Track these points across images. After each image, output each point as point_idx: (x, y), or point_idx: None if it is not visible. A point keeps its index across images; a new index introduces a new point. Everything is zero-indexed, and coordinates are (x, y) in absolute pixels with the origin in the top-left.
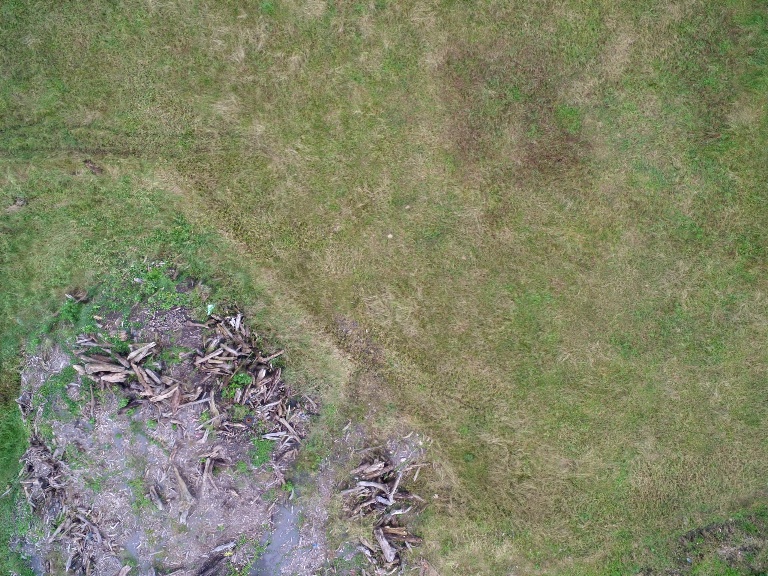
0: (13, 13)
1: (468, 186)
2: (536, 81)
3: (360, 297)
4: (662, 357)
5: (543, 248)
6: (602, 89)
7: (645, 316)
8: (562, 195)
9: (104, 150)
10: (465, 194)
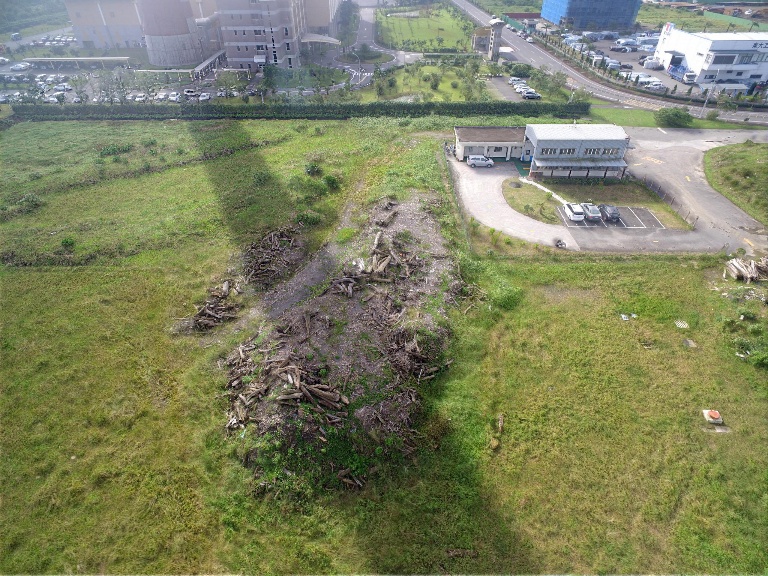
0: None
1: None
2: None
3: (135, 419)
4: None
5: None
6: None
7: None
8: None
9: None
10: None
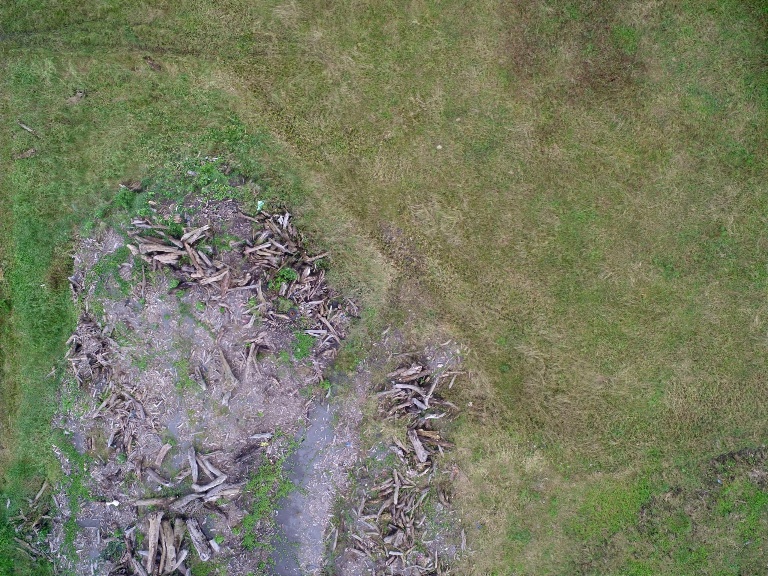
0: None
1: (520, 101)
2: (594, 1)
3: (406, 205)
4: (704, 281)
5: (591, 166)
6: (660, 12)
7: (689, 239)
8: (613, 115)
9: (163, 48)
10: (516, 109)
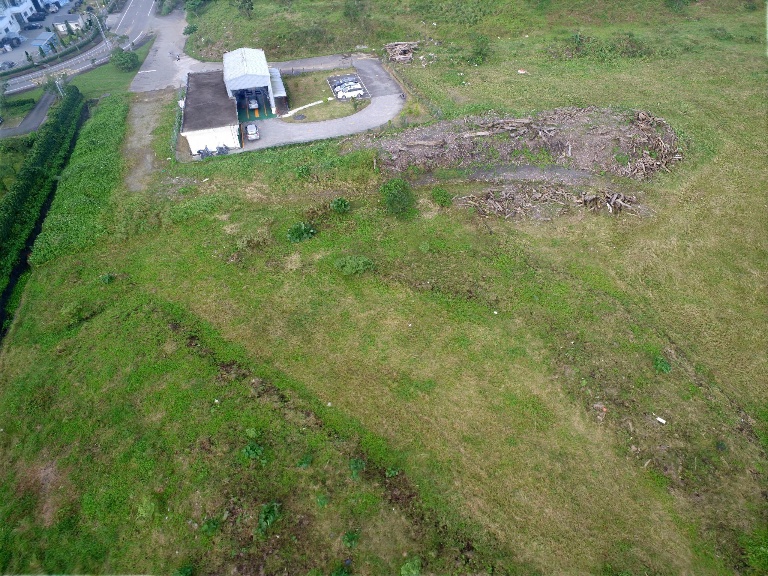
0: (767, 110)
1: None
2: None
3: None
4: None
5: None
6: None
7: None
8: None
9: None
10: None
